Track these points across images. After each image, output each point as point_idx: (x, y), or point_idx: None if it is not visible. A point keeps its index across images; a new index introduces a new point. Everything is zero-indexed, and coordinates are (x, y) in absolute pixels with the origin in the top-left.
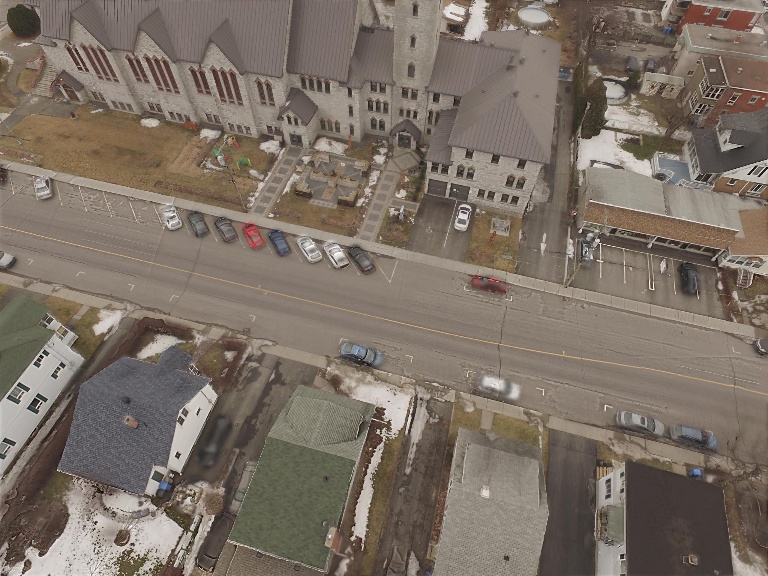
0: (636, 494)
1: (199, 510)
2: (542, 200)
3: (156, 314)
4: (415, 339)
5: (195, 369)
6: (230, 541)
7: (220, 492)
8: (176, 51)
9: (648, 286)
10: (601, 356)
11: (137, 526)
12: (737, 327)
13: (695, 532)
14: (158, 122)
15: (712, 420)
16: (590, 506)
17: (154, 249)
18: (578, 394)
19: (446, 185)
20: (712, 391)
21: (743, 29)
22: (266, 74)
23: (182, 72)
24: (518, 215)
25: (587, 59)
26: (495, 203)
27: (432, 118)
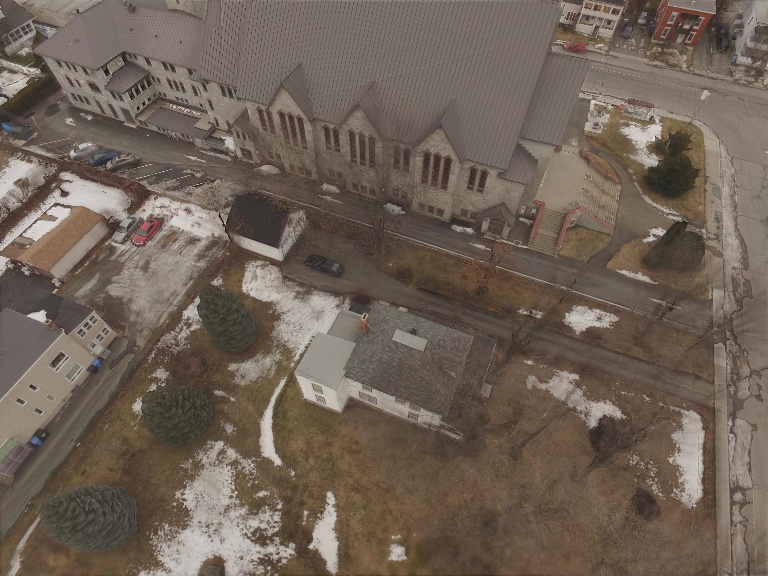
0: None
1: None
2: None
3: None
4: None
5: None
6: None
7: None
8: None
9: None
10: None
11: None
12: None
13: None
14: None
15: None
16: None
17: None
18: None
19: None
20: None
21: None
22: None
23: None
24: None
25: None
26: None
27: None
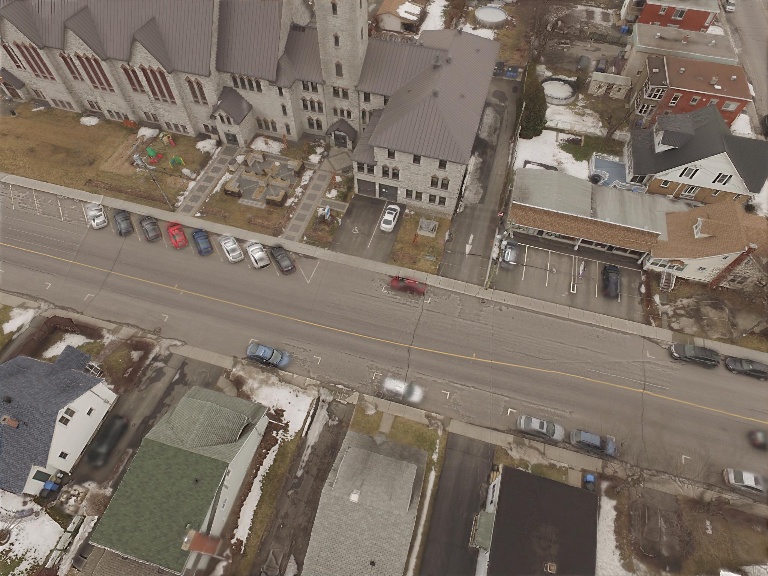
0: (508, 500)
1: (82, 510)
2: (474, 201)
3: (69, 313)
4: (325, 340)
5: (97, 369)
6: (91, 543)
7: (107, 493)
8: (106, 49)
9: (570, 289)
10: (512, 359)
11: (19, 526)
12: (655, 331)
13: (562, 540)
14: (97, 120)
15: (616, 425)
16: (479, 511)
17: (76, 248)
18: (483, 397)
19: (375, 185)
20: (620, 396)
21: (699, 29)
22: (193, 73)
23: (115, 70)
24: (447, 216)
25: (538, 58)
26: (424, 204)
27: (366, 118)
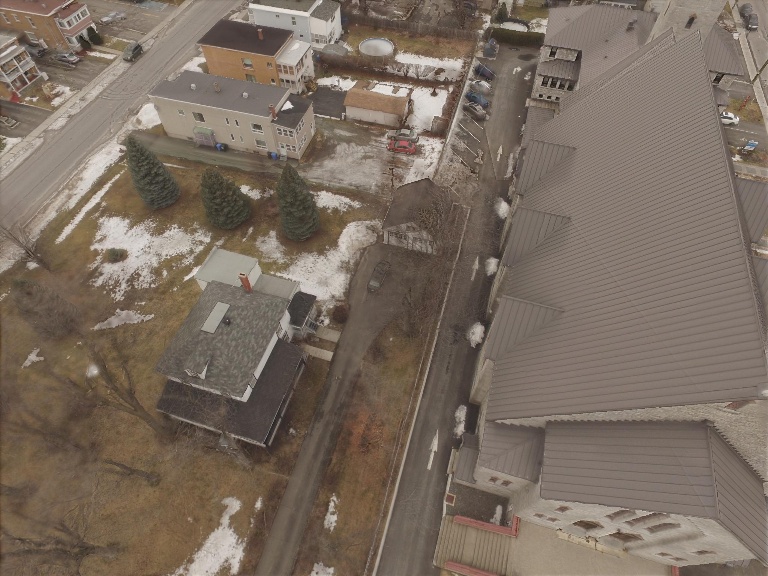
0: None
1: None
2: None
3: None
4: None
5: None
6: None
7: None
8: None
9: None
10: None
11: None
12: (741, 32)
13: None
14: None
15: None
16: None
17: None
18: None
19: None
20: None
21: None
22: None
23: None
24: None
25: None
26: None
27: None
